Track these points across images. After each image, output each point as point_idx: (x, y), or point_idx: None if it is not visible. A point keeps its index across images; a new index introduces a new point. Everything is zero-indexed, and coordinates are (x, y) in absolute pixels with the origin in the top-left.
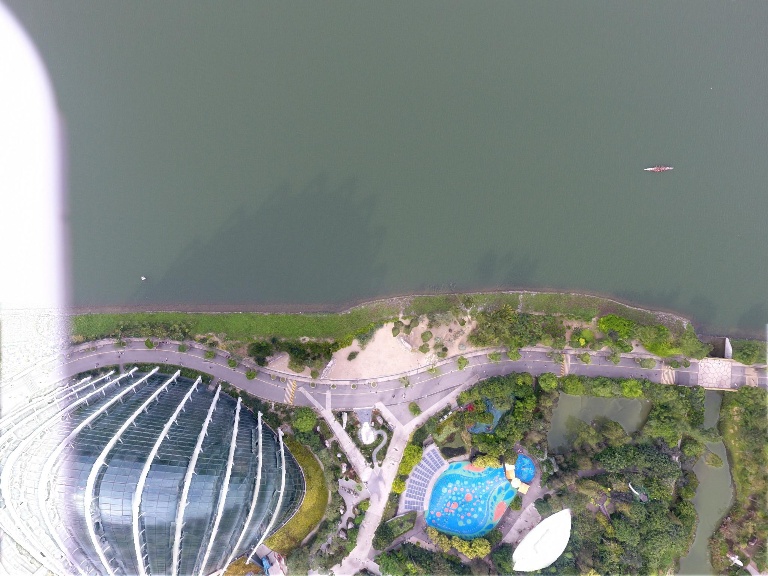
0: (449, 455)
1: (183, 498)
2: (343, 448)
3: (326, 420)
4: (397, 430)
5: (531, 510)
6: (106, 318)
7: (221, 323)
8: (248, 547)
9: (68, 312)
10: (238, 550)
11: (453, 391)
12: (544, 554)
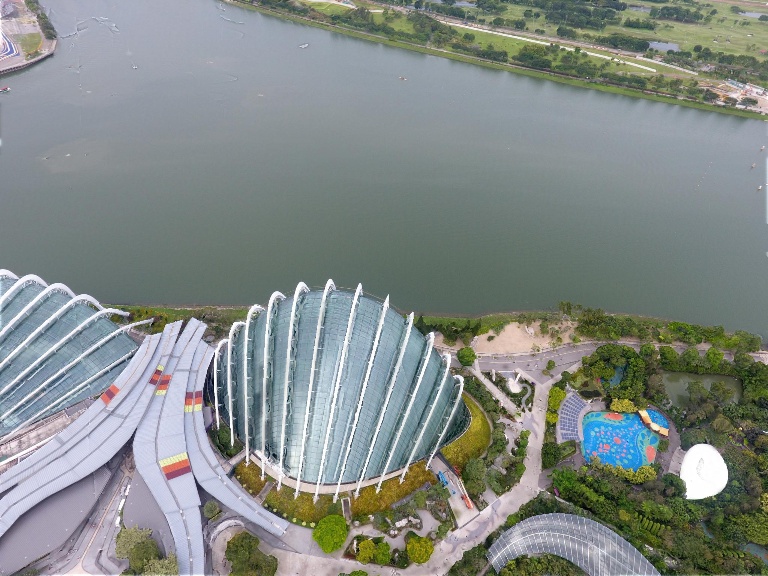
0: (588, 396)
1: None
2: (495, 397)
3: (477, 378)
4: (537, 387)
5: (680, 454)
6: None
7: None
8: (427, 452)
9: None
10: (422, 443)
11: (575, 364)
12: (710, 482)
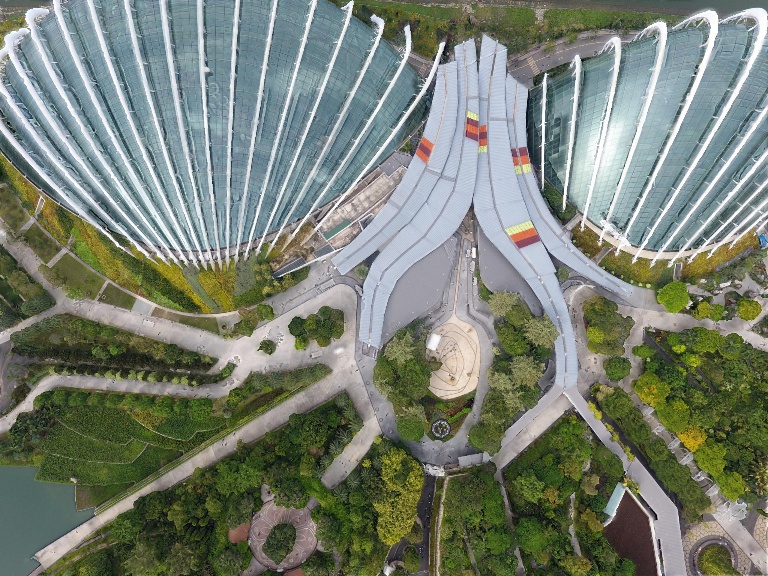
0: None
1: None
2: None
3: None
4: None
5: None
6: (598, 13)
7: None
8: None
9: (561, 6)
10: None
11: None
12: None
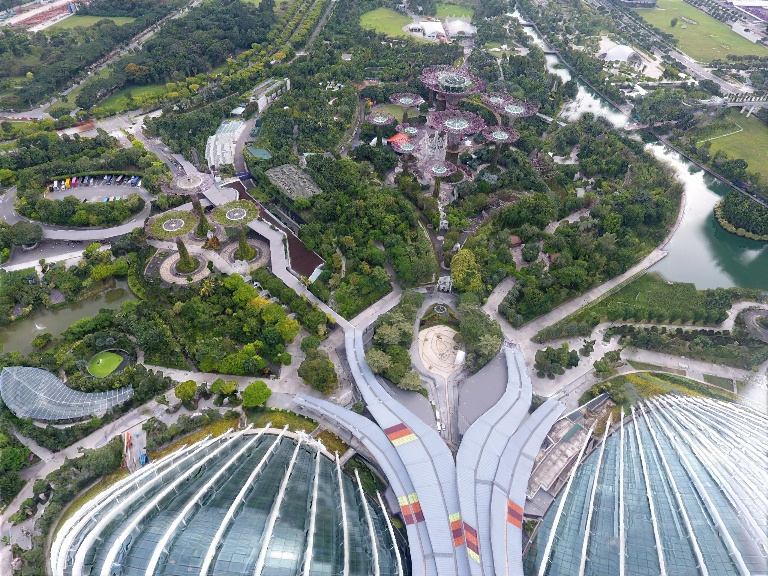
0: None
1: (81, 547)
2: None
3: None
4: None
5: None
6: None
7: None
8: None
9: None
10: None
11: None
12: None
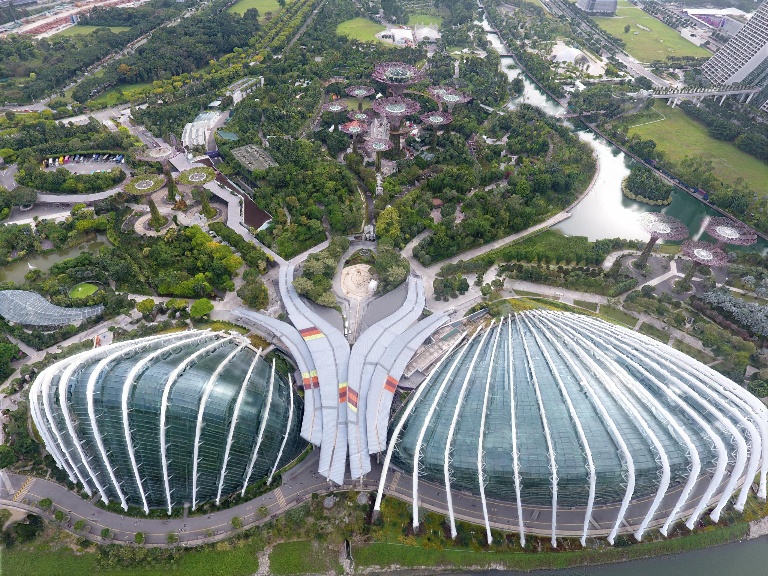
0: None
1: (49, 371)
2: (3, 437)
3: None
4: None
5: None
6: (193, 574)
7: (63, 568)
8: None
9: None
10: None
11: None
12: None
